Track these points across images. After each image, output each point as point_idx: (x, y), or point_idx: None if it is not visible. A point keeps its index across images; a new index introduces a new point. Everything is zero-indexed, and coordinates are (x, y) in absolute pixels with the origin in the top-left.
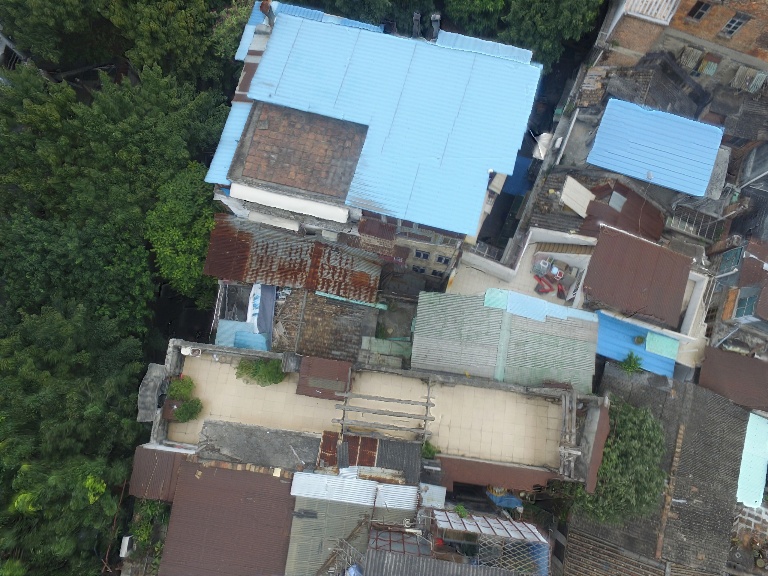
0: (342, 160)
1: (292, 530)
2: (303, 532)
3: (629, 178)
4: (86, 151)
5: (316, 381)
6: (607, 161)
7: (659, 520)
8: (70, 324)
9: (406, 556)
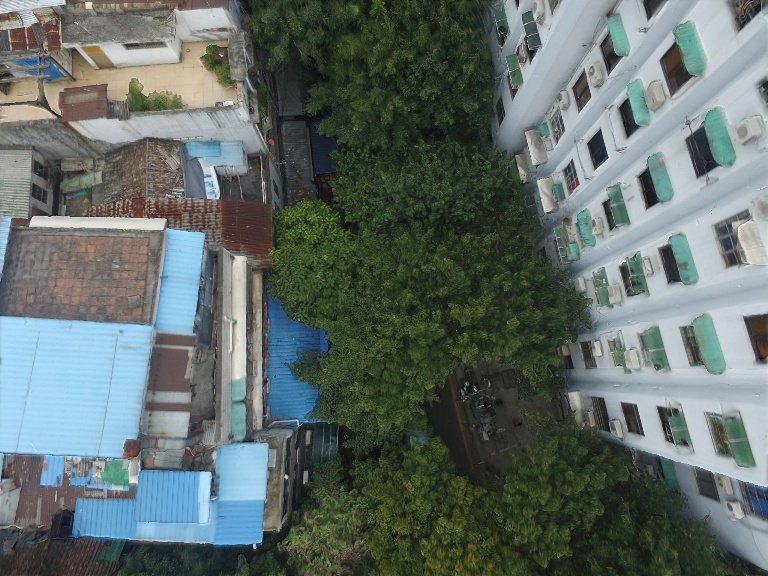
0: None
1: None
2: None
3: None
4: None
5: (91, 98)
6: None
7: None
8: (355, 109)
9: None
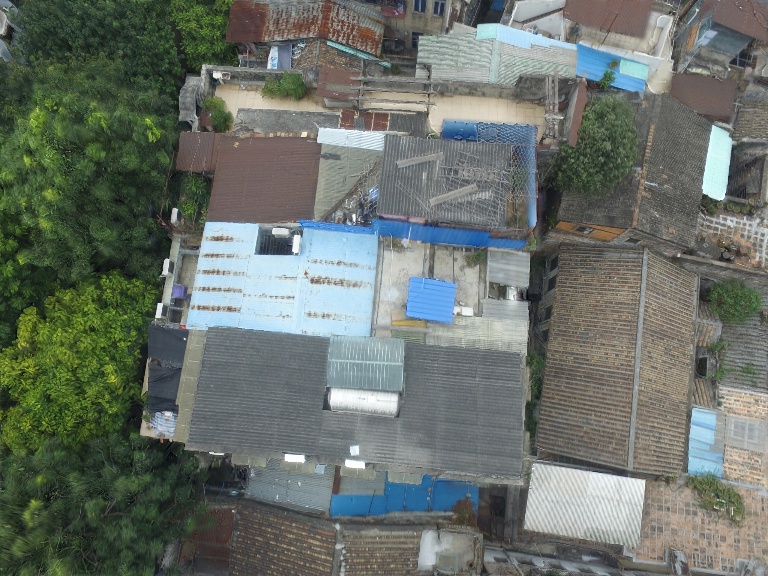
0: None
1: (320, 167)
2: (329, 170)
3: None
4: None
5: (333, 86)
6: None
7: (634, 199)
8: (113, 64)
9: (418, 138)
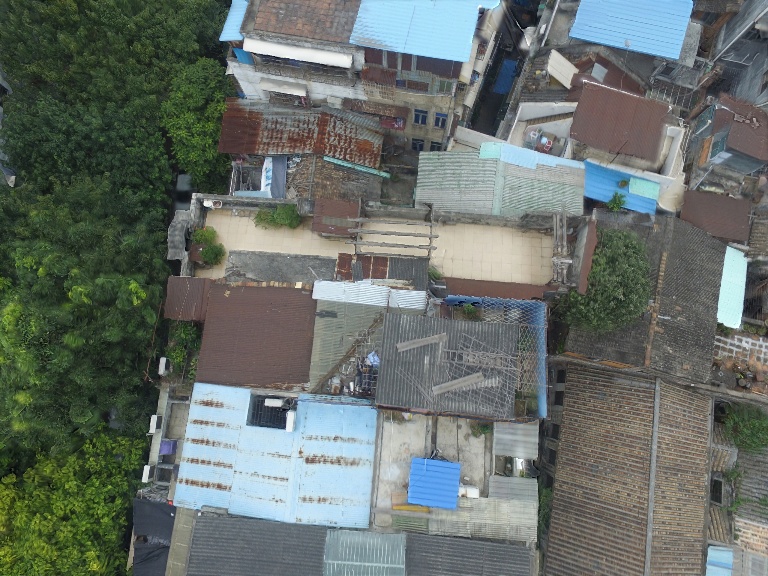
0: (344, 11)
1: (315, 327)
2: (325, 329)
3: (609, 48)
4: (103, 44)
5: (329, 219)
6: (588, 34)
7: (646, 334)
8: (99, 188)
9: (419, 317)
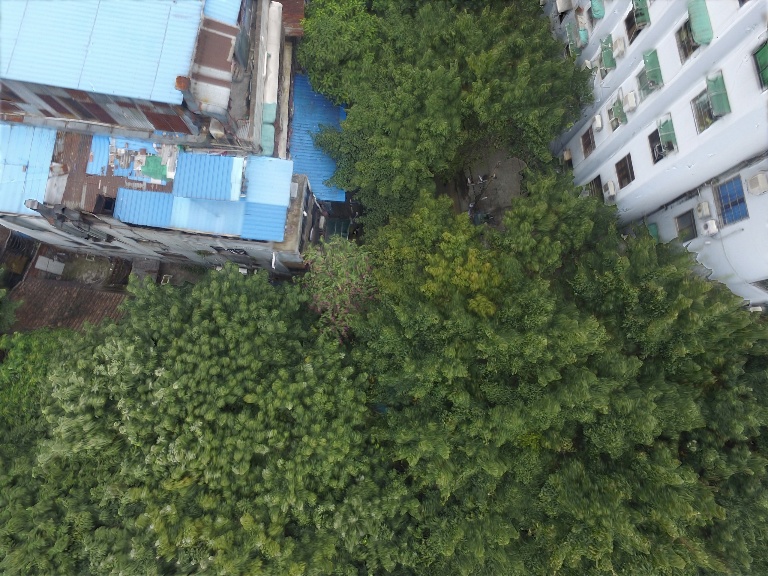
0: None
1: None
2: None
3: None
4: None
5: None
6: None
7: None
8: None
9: None
